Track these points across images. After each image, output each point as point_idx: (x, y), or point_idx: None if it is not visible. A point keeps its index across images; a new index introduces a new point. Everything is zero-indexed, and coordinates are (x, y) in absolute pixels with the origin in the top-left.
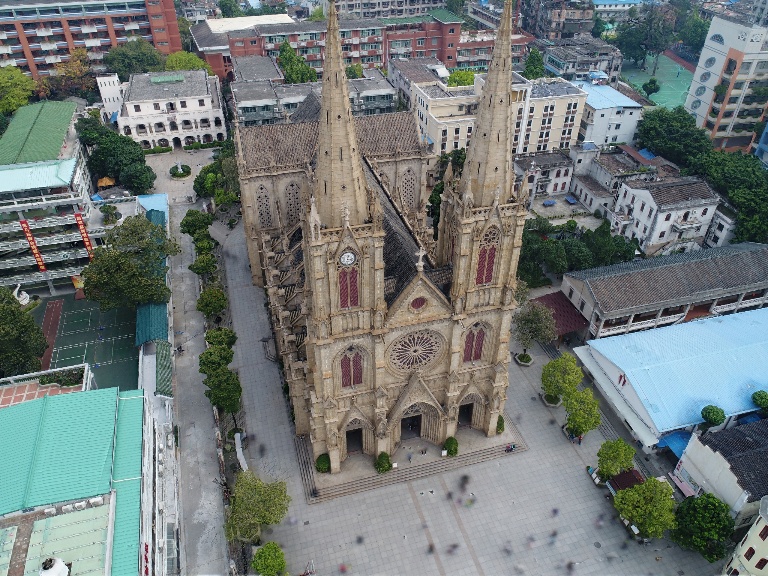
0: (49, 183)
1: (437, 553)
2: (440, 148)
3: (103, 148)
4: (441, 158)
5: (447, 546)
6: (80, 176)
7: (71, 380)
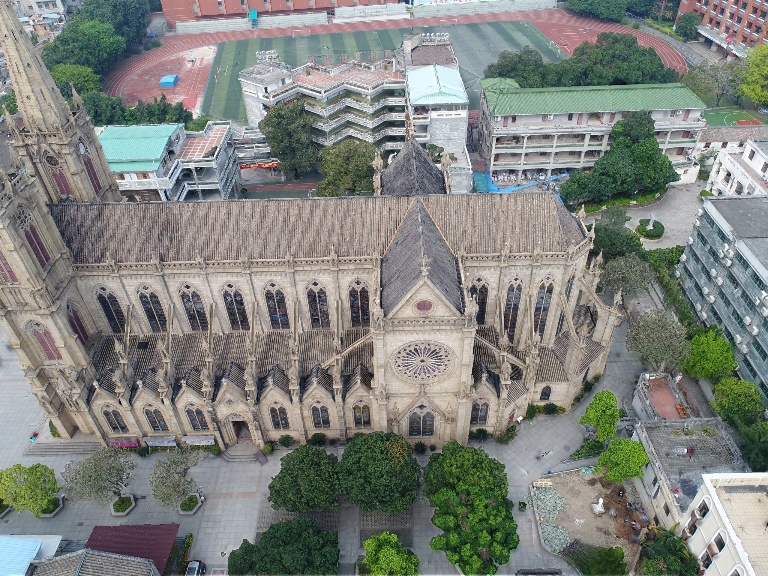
0: (415, 97)
1: (9, 361)
2: (688, 520)
3: (612, 145)
4: (669, 530)
5: (8, 368)
6: (460, 117)
7: (206, 156)
